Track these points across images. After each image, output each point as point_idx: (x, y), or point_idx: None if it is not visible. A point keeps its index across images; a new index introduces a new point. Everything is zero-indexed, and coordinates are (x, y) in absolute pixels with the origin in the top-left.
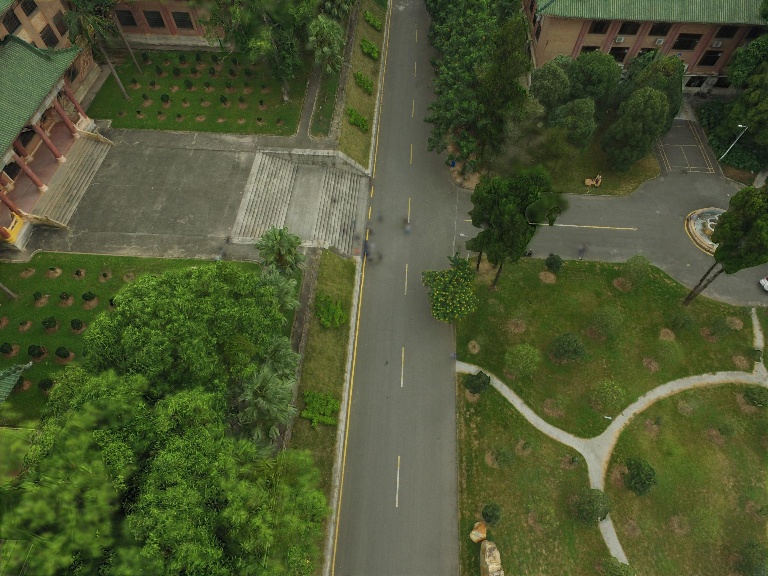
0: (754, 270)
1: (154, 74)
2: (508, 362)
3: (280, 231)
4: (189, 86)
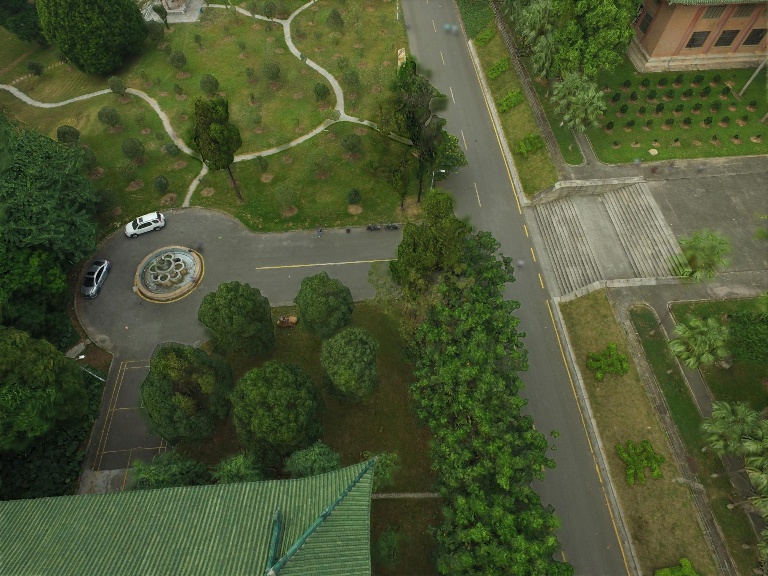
0: (160, 239)
1: None
2: None
3: (593, 107)
4: None
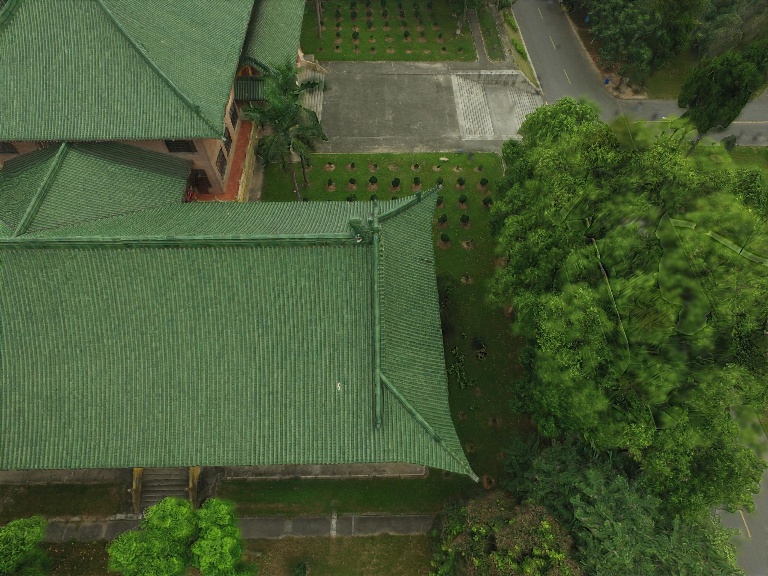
0: None
1: (332, 19)
2: (727, 207)
3: None
4: (370, 26)
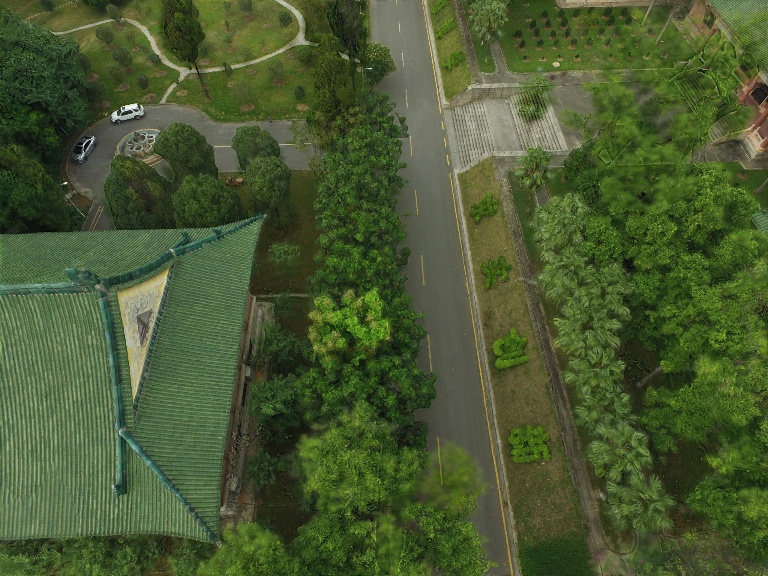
0: (139, 125)
1: None
2: None
3: (495, 16)
4: None
